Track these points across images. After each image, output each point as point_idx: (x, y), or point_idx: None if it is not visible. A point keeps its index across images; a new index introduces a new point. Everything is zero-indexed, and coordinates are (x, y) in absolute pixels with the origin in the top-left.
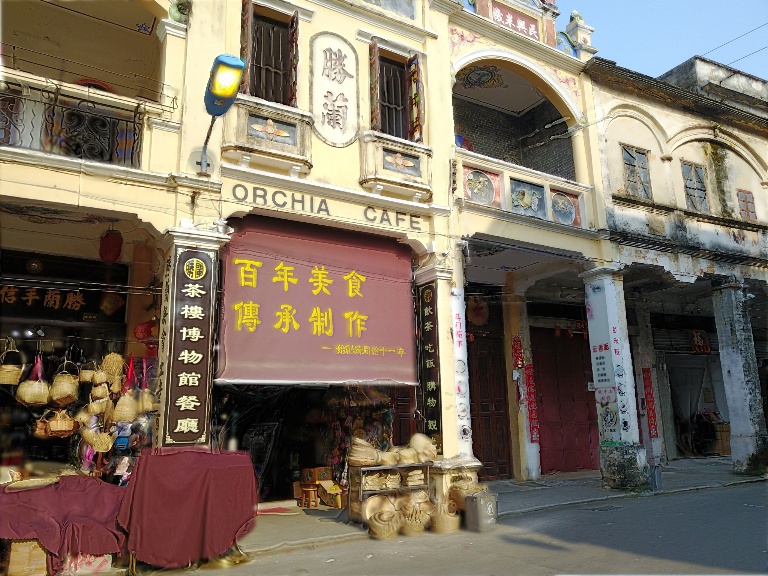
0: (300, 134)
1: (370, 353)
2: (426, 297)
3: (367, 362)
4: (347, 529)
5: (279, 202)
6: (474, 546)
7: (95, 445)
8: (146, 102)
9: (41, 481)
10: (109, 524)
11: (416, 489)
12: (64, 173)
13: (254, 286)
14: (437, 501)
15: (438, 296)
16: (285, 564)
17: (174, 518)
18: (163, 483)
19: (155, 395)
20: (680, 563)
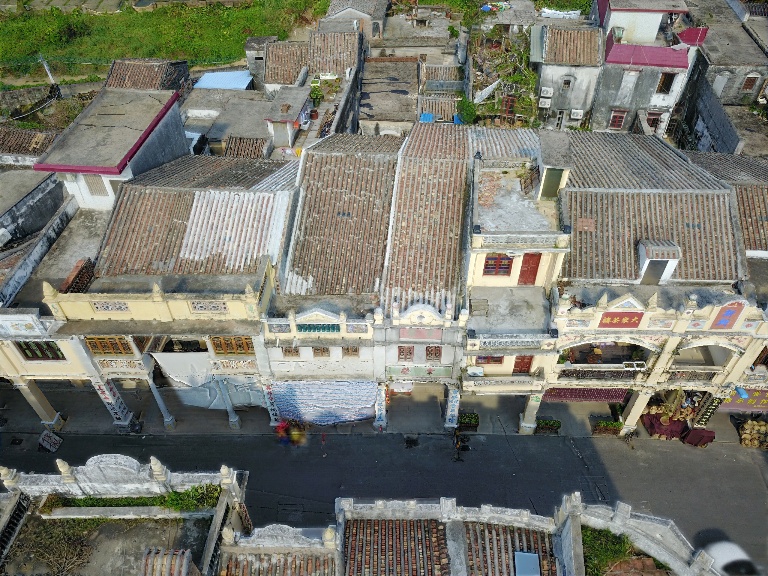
0: (767, 378)
1: (765, 407)
2: None
3: (763, 408)
4: (734, 439)
5: (751, 387)
6: (761, 469)
7: (680, 419)
8: (719, 371)
9: (667, 419)
10: (679, 433)
11: (761, 434)
12: None
13: (733, 395)
14: (766, 438)
15: None
16: (714, 454)
17: (693, 439)
18: (693, 434)
19: (696, 413)
20: None
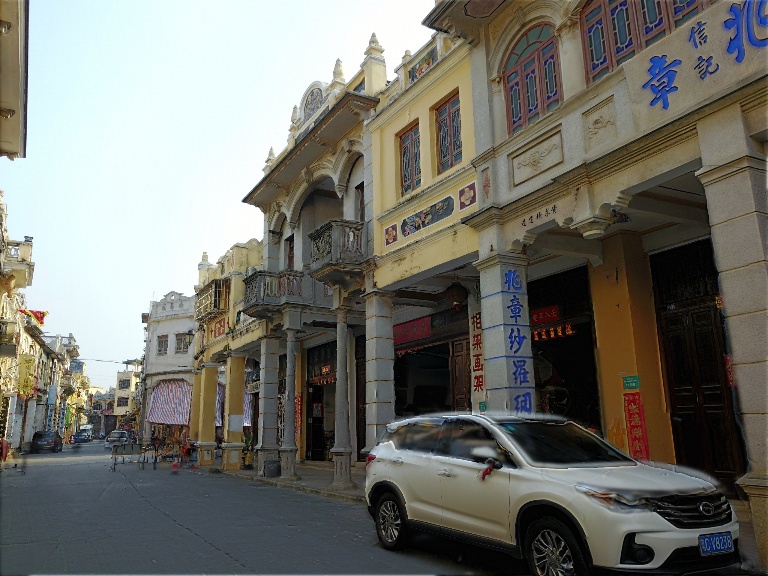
0: None
1: None
2: (3, 401)
3: None
4: None
5: None
6: None
7: None
8: None
9: None
10: None
11: None
12: (1, 378)
13: None
14: None
15: (9, 402)
16: None
17: None
18: None
19: None
20: (69, 456)
